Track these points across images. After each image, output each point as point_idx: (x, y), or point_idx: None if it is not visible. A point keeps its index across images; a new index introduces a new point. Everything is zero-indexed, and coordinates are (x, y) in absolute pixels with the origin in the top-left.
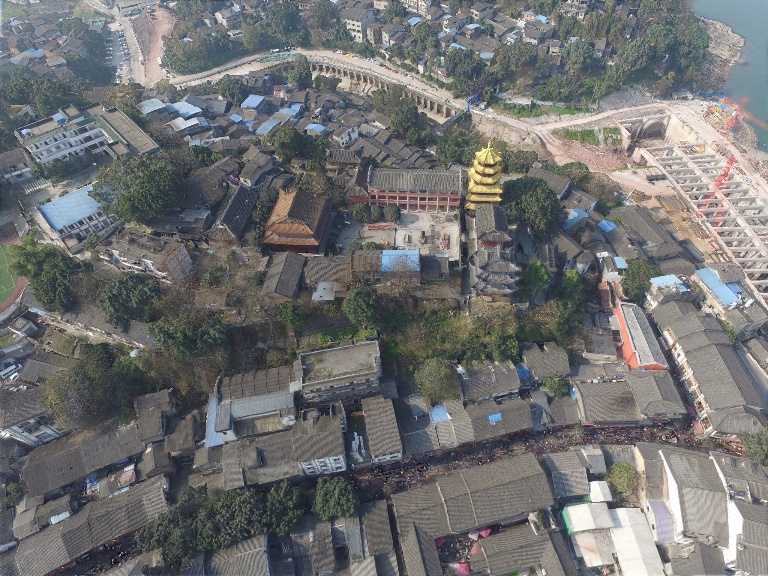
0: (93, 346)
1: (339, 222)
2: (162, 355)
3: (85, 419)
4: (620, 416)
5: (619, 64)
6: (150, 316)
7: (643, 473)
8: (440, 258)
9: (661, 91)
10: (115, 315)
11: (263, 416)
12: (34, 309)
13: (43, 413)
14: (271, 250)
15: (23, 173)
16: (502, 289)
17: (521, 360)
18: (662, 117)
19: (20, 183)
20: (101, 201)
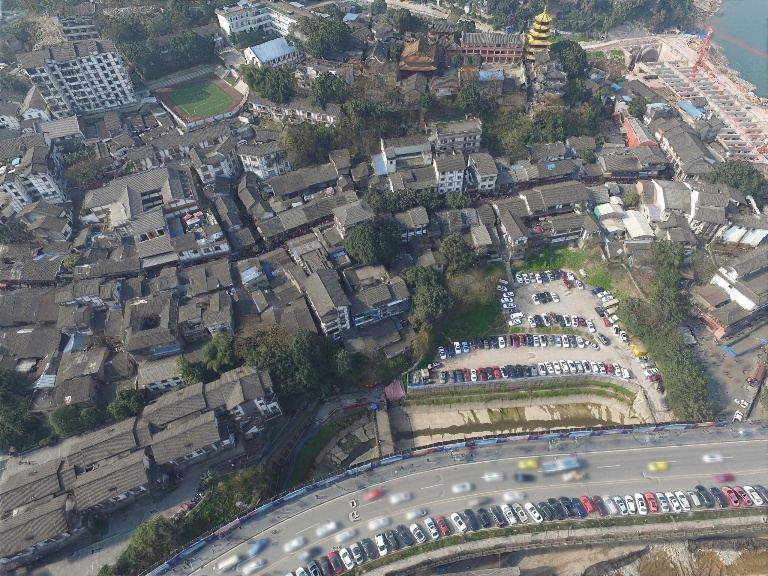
0: (298, 124)
1: (443, 65)
2: (346, 125)
3: (305, 155)
4: (628, 167)
5: (623, 4)
6: (339, 100)
7: (642, 193)
8: (514, 77)
9: (655, 26)
10: (321, 96)
11: (411, 158)
12: (256, 105)
13: (279, 151)
14: (401, 78)
15: (217, 41)
16: (555, 93)
17: (565, 143)
18: (656, 46)
19: (214, 49)
20: (294, 42)
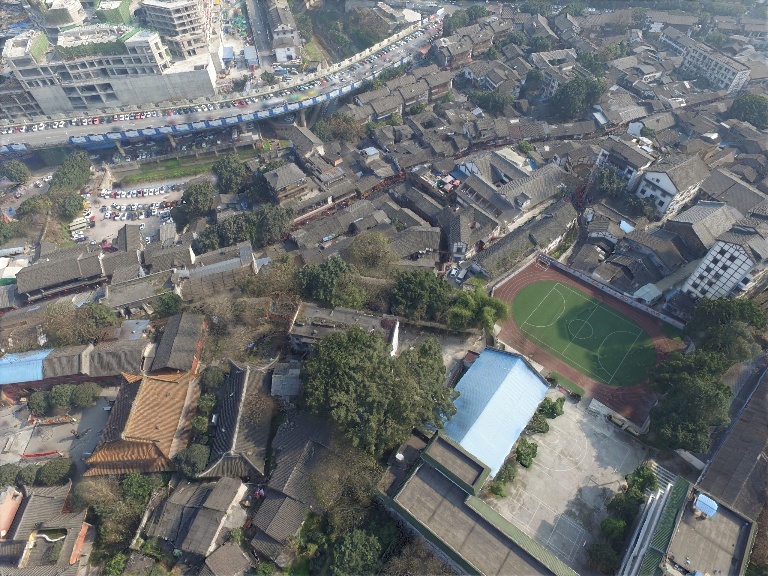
0: None
1: None
2: None
3: None
4: None
5: None
6: None
7: None
8: None
9: None
10: None
11: None
12: None
13: None
14: None
15: None
16: None
17: None
18: None
19: None
20: None
